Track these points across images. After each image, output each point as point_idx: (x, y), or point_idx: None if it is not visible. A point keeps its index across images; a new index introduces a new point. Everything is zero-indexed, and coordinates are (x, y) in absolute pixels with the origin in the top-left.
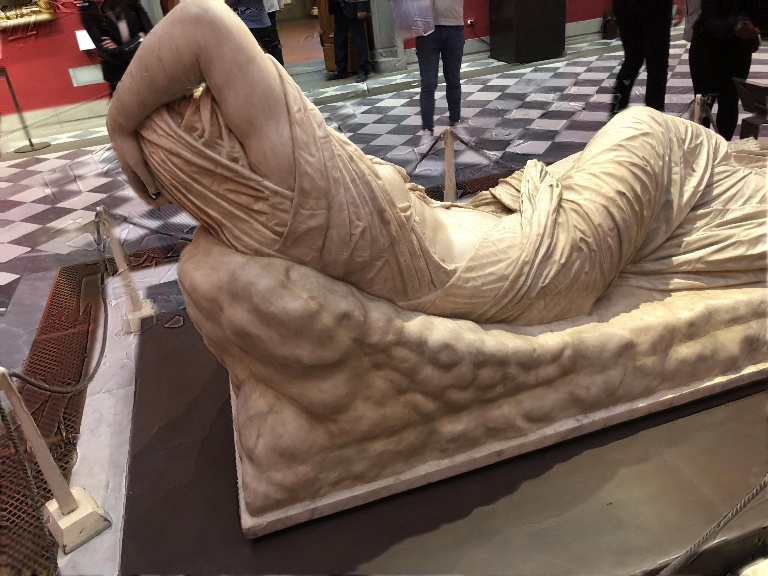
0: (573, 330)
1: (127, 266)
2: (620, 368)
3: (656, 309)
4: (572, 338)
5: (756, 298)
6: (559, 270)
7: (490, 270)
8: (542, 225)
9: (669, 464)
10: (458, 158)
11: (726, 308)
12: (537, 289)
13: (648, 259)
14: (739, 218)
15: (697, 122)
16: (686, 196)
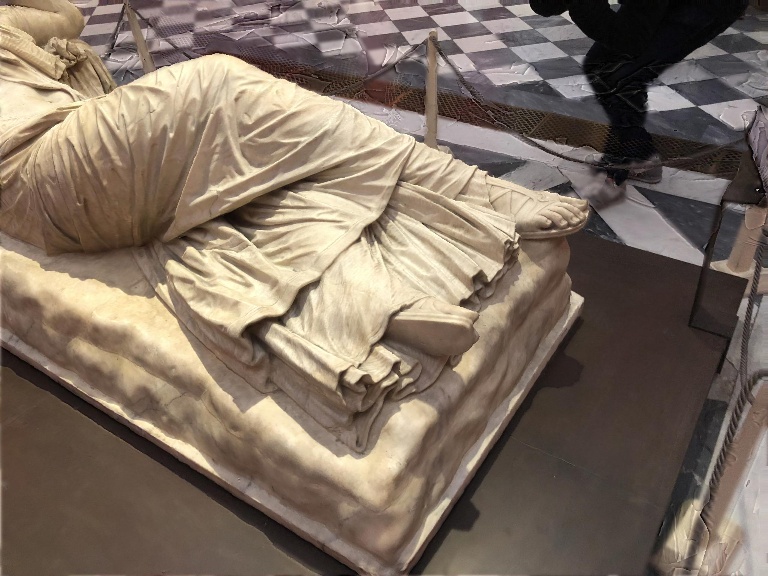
0: (11, 255)
1: (144, 60)
2: (28, 318)
3: (96, 293)
4: None
5: (172, 358)
6: (2, 189)
7: None
8: (7, 137)
9: (1, 424)
10: (441, 75)
11: (139, 342)
12: None
13: (169, 248)
14: None
15: (765, 162)
16: (203, 197)
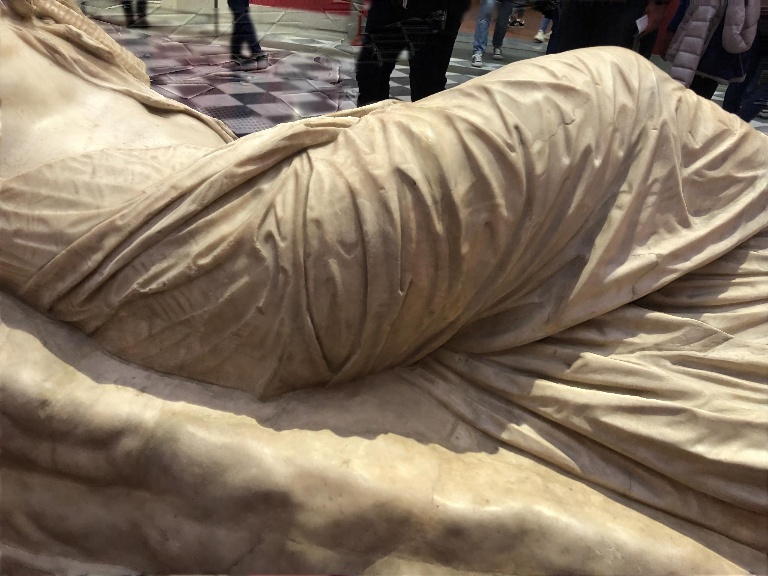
0: (185, 409)
1: None
2: (244, 534)
3: (410, 459)
4: (159, 422)
5: (662, 559)
6: (190, 276)
7: (43, 212)
8: (202, 174)
9: None
10: None
11: (568, 541)
12: (125, 292)
13: (499, 360)
14: (737, 366)
15: None
16: (628, 266)
